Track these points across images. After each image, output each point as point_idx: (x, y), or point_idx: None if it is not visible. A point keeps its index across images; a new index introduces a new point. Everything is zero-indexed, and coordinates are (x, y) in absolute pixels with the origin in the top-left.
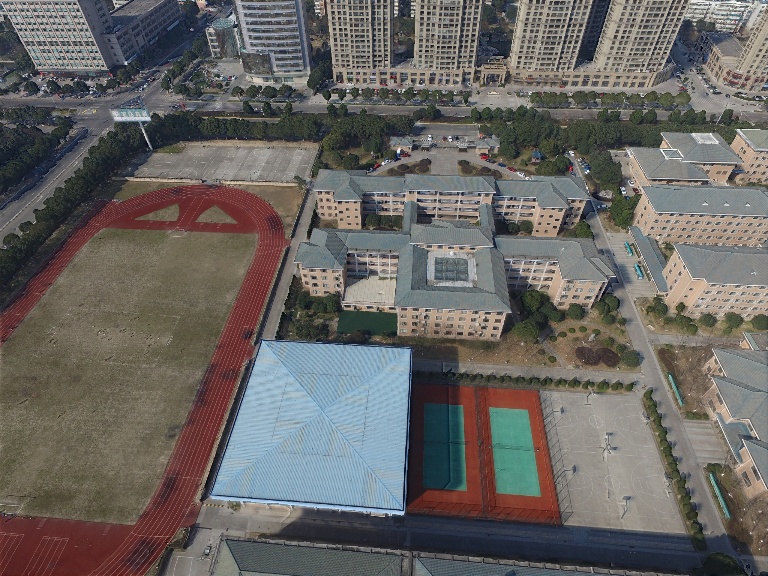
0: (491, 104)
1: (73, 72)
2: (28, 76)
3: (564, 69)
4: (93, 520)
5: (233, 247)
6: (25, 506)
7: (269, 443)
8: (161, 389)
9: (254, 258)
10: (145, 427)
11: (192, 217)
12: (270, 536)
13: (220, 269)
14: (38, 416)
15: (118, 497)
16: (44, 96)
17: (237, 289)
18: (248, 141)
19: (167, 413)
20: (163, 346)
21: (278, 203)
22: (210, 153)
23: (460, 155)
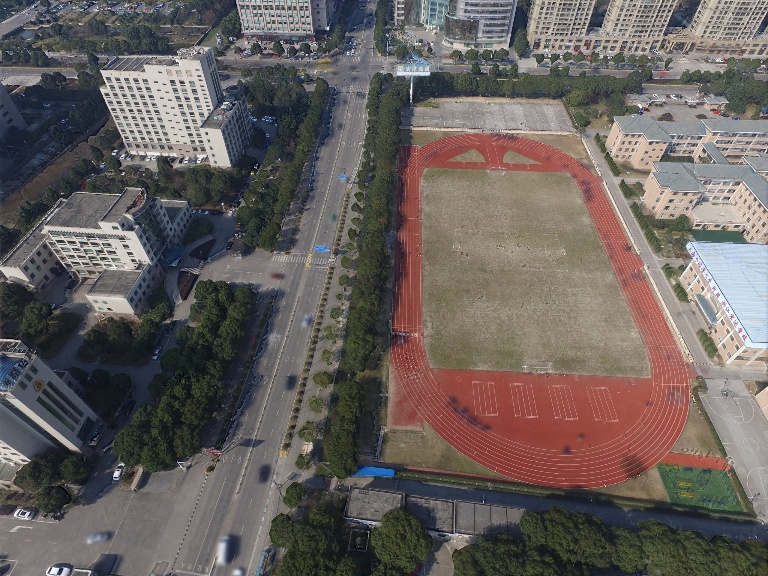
0: (686, 69)
1: (277, 36)
2: (232, 39)
3: (744, 38)
4: (615, 375)
5: (555, 182)
6: (552, 367)
7: (767, 309)
8: (589, 287)
9: (581, 191)
10: (600, 313)
11: (498, 159)
12: (765, 382)
13: (559, 199)
14: (503, 307)
15: (622, 360)
16: (263, 58)
17: (587, 214)
18: (492, 98)
19: (609, 303)
20: (562, 256)
21: (565, 148)
22: (467, 107)
23: (693, 110)
